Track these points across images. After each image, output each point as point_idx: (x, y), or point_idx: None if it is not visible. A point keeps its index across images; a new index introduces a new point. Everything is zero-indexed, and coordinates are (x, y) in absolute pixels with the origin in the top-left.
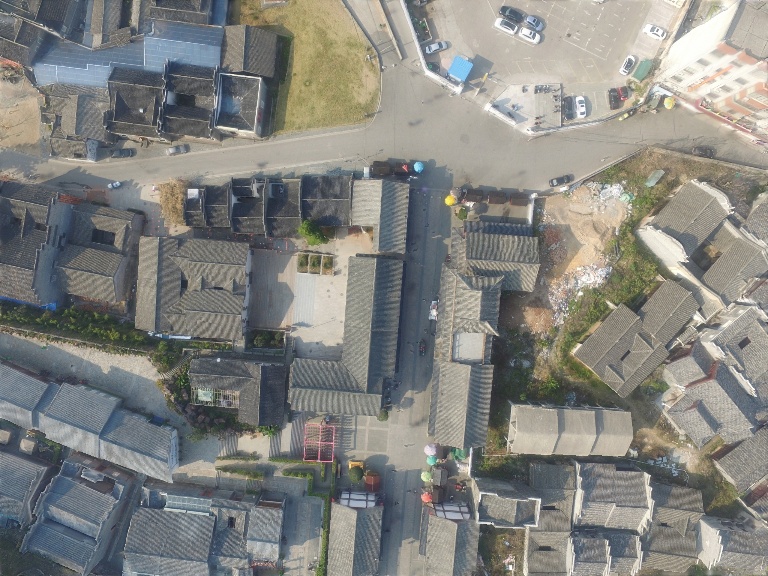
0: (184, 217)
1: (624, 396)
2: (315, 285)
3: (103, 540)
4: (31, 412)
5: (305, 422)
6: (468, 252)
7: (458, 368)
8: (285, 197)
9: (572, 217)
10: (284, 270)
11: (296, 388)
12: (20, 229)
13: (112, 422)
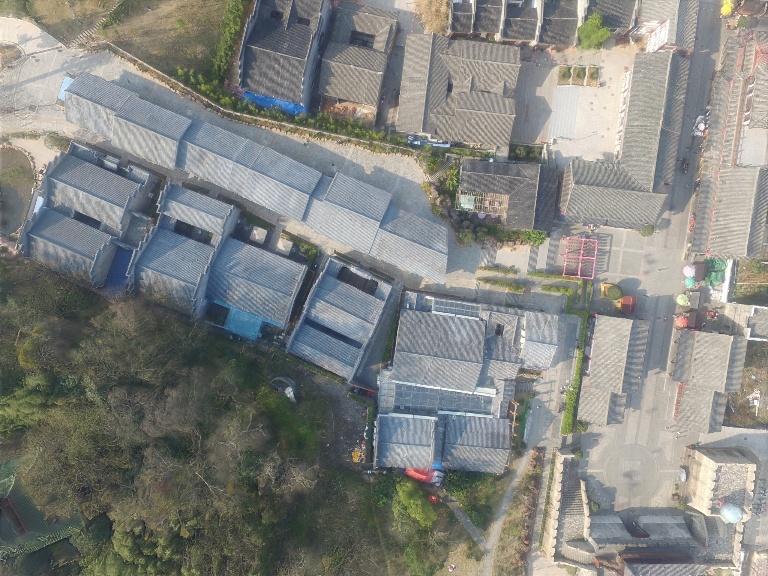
0: (452, 18)
1: None
2: (578, 97)
3: None
4: (308, 197)
5: (559, 241)
6: (762, 49)
7: (742, 172)
8: (557, 1)
9: None
10: (543, 83)
11: (581, 185)
12: (282, 22)
13: (388, 214)
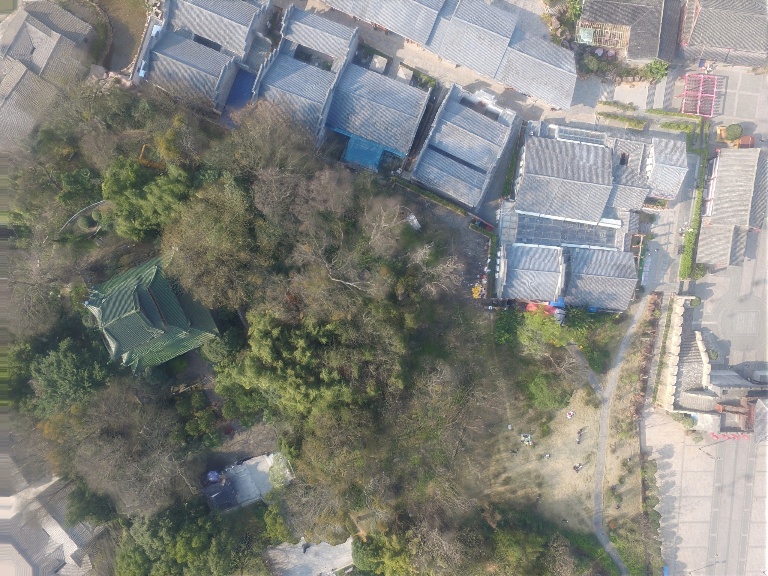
0: None
1: None
2: None
3: None
4: (437, 15)
5: (674, 83)
6: None
7: None
8: None
9: None
10: None
11: (708, 8)
12: None
13: (515, 36)
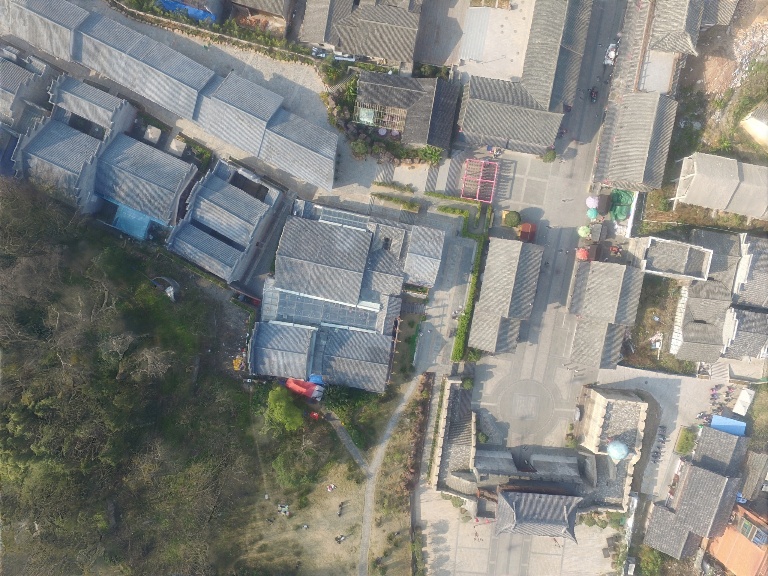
0: None
1: None
2: (489, 19)
3: (250, 249)
4: (197, 93)
5: (462, 164)
6: None
7: (644, 97)
8: None
9: None
10: (455, 5)
11: (475, 99)
12: None
13: (278, 117)
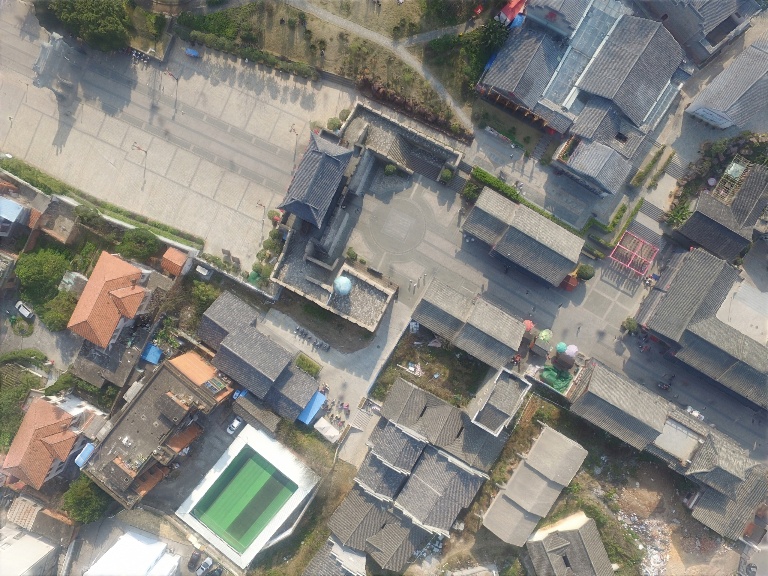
0: None
1: (529, 544)
2: None
3: (670, 4)
4: None
5: None
6: (763, 478)
7: (661, 420)
8: None
9: (714, 570)
10: None
11: None
12: None
13: None
